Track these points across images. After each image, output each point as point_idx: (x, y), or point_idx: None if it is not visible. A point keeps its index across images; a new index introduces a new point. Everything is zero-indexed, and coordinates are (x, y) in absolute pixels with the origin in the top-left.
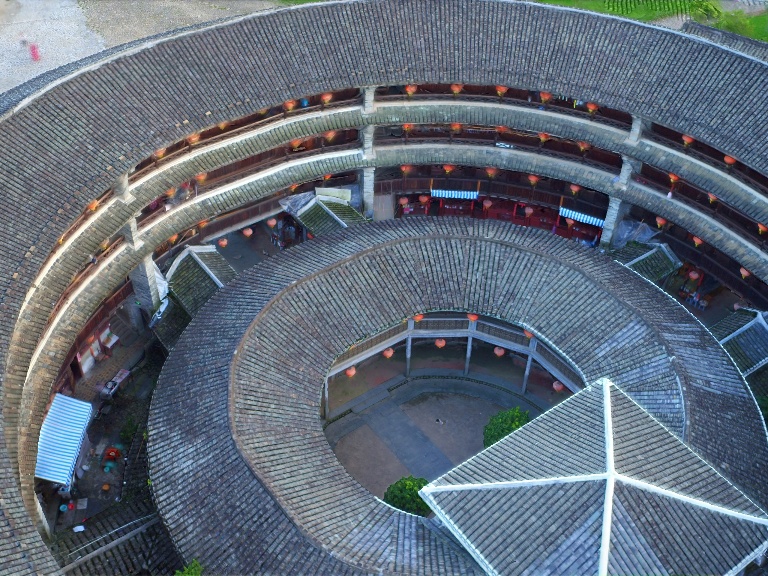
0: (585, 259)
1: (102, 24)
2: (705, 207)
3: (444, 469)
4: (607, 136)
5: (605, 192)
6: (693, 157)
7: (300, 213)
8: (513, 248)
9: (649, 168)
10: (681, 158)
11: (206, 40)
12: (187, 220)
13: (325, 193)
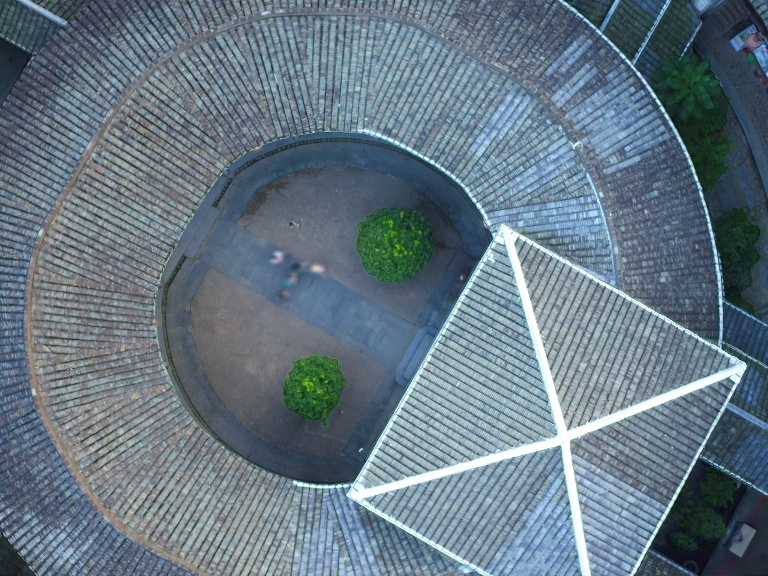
0: None
1: None
2: None
3: (325, 291)
4: None
5: None
6: None
7: None
8: (308, 17)
9: None
10: None
11: None
12: None
13: None
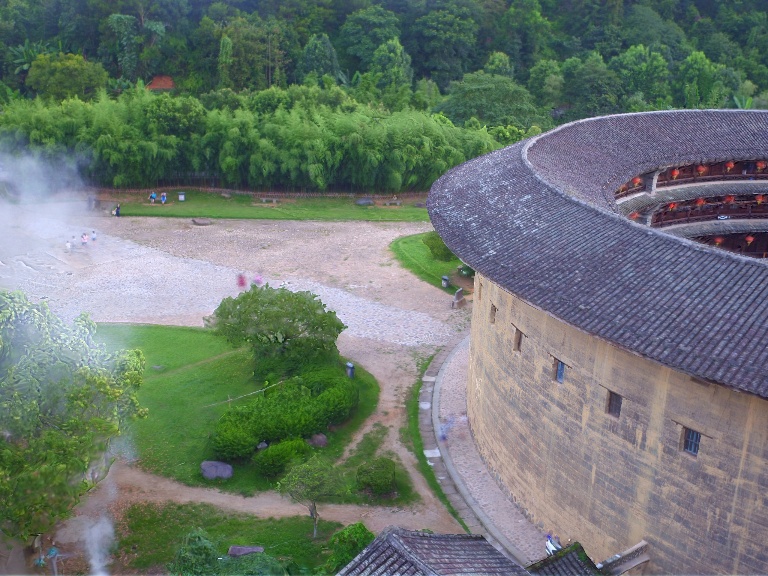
0: None
1: (188, 253)
2: None
3: None
4: None
5: None
6: None
7: None
8: None
9: None
10: None
11: (555, 140)
12: None
13: None
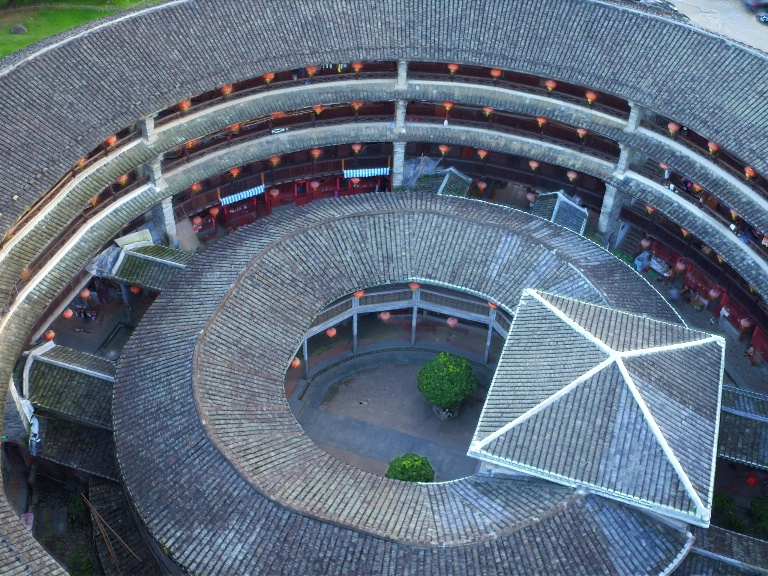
0: (422, 202)
1: None
2: (479, 122)
3: (398, 441)
4: (378, 89)
5: (389, 140)
6: (459, 82)
7: (115, 271)
8: (365, 216)
9: (412, 106)
10: (449, 86)
11: None
12: (25, 324)
13: (127, 242)
